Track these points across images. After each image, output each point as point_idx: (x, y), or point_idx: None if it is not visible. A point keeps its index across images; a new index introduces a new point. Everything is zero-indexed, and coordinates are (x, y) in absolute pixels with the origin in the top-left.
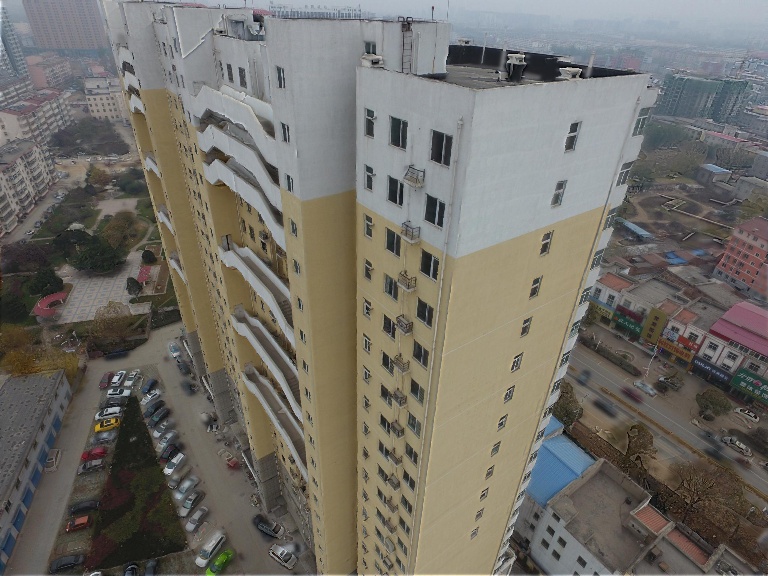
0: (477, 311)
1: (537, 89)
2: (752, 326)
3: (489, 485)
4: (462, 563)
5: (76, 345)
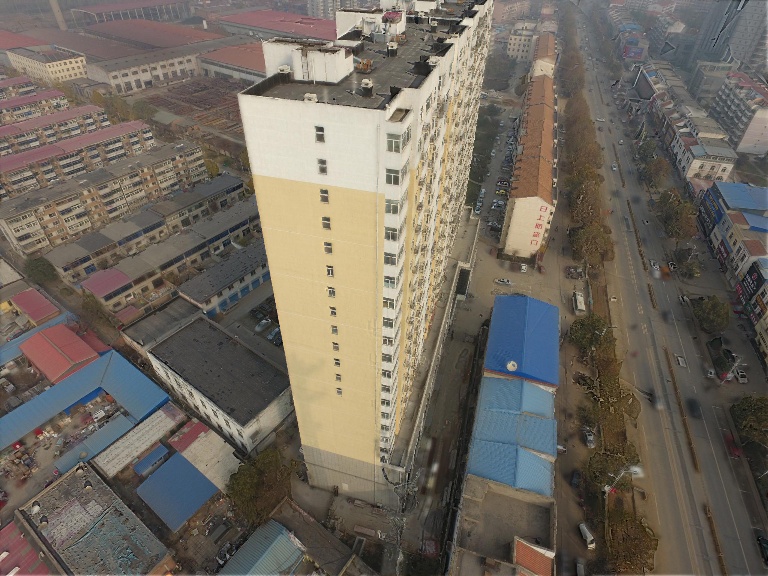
0: (279, 213)
1: (274, 101)
2: None
3: (339, 358)
4: (335, 409)
5: None
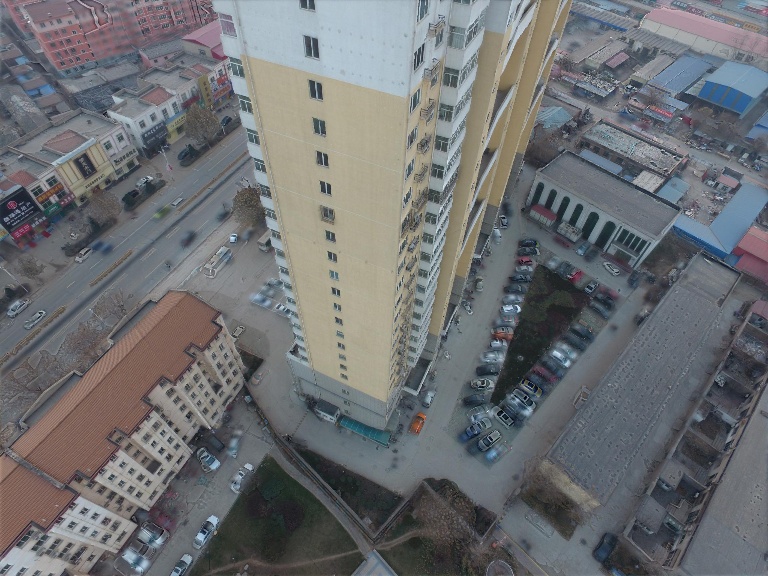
0: None
1: None
2: (219, 39)
3: None
4: None
5: (494, 569)
